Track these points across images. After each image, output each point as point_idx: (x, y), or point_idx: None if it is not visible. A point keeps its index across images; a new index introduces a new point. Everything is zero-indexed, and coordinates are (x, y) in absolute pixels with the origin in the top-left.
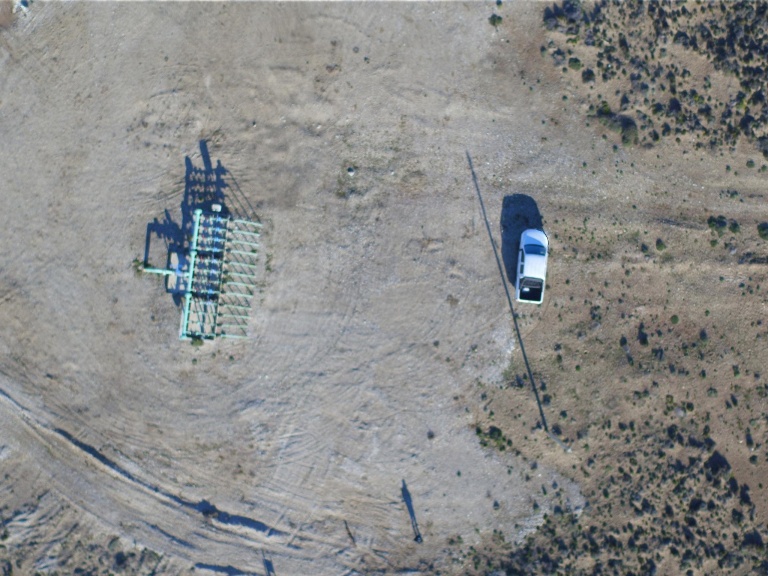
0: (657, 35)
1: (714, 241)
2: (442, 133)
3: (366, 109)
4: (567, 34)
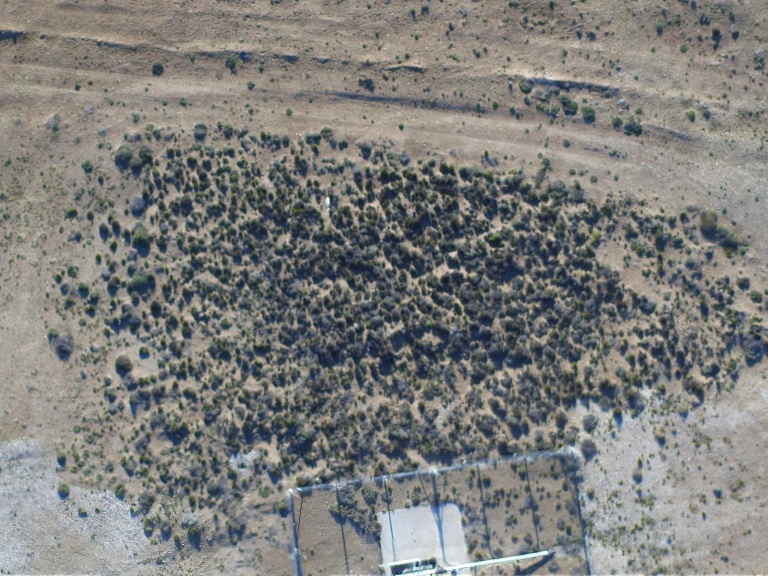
0: (673, 314)
1: (639, 113)
2: None
3: None
4: (762, 327)
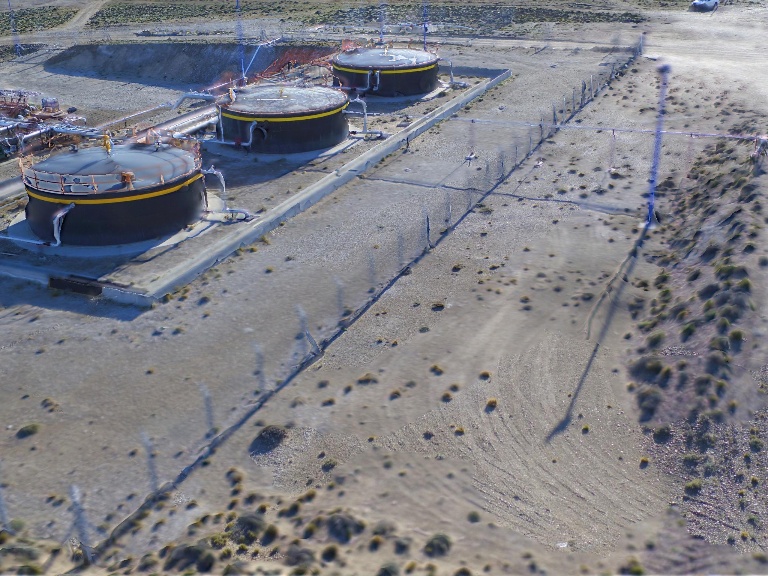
0: None
1: None
2: (720, 19)
3: (756, 24)
4: None
